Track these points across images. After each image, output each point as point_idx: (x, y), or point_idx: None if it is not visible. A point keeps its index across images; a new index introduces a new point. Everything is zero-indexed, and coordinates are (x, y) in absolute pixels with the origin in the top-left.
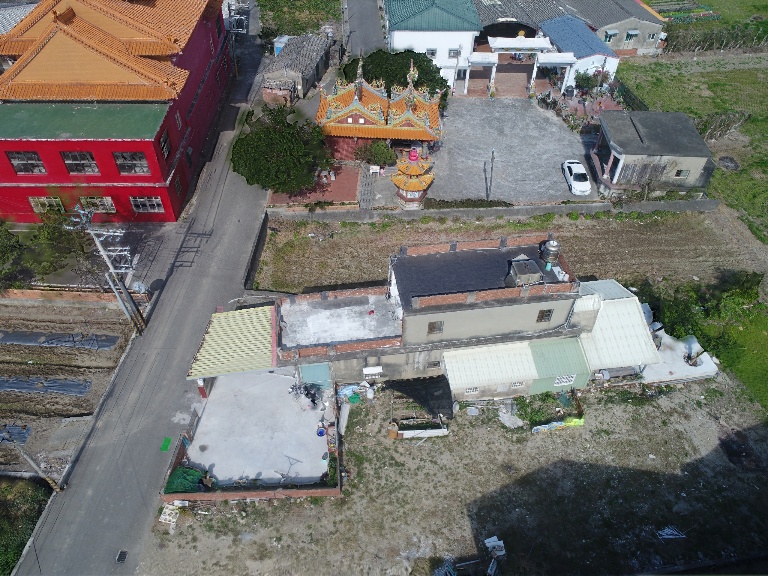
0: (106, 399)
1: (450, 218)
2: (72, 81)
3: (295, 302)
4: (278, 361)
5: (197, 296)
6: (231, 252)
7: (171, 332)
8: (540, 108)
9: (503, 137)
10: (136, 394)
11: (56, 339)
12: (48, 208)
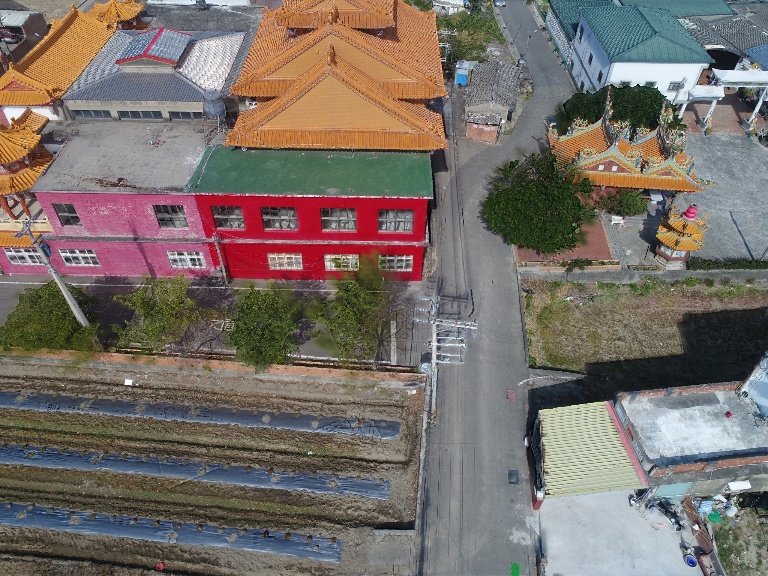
0: (424, 509)
1: (717, 280)
2: (328, 127)
3: (634, 399)
4: (648, 478)
5: (480, 376)
6: (498, 321)
7: (467, 422)
8: (764, 147)
9: (737, 181)
10: (457, 503)
11: (331, 424)
12: (285, 265)
